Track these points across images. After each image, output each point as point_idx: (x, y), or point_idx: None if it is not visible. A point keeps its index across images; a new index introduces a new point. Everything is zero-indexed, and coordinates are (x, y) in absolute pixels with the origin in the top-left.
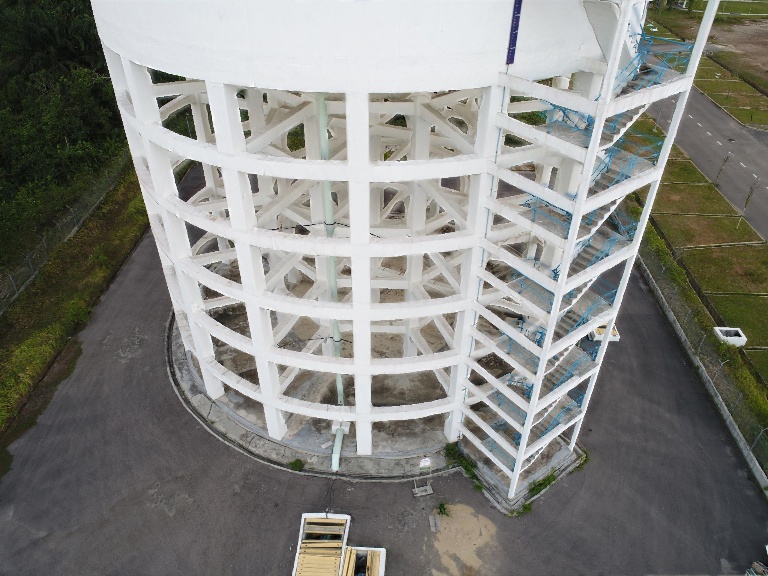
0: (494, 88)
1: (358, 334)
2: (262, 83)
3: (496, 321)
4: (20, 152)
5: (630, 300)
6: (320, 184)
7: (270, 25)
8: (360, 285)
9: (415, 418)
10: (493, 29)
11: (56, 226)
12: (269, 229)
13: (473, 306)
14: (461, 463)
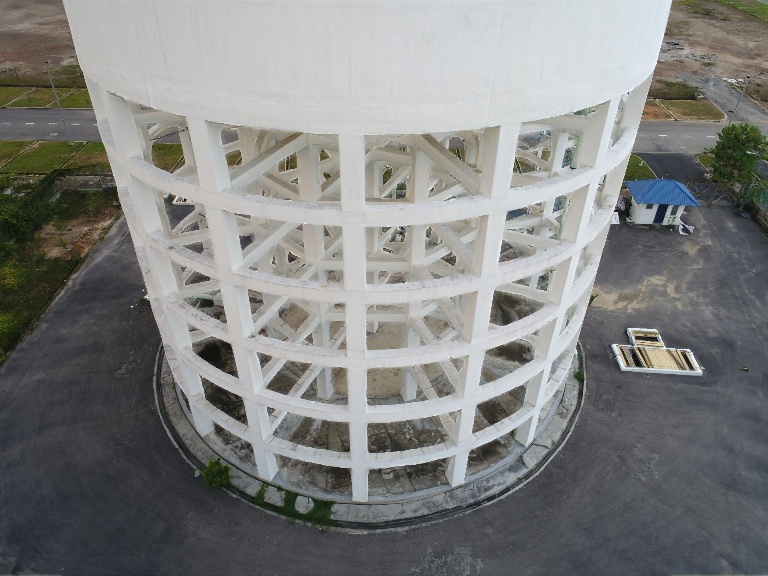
0: None
1: None
2: None
3: None
4: None
5: None
6: None
7: None
8: None
9: None
10: None
11: None
12: None
13: None
14: None
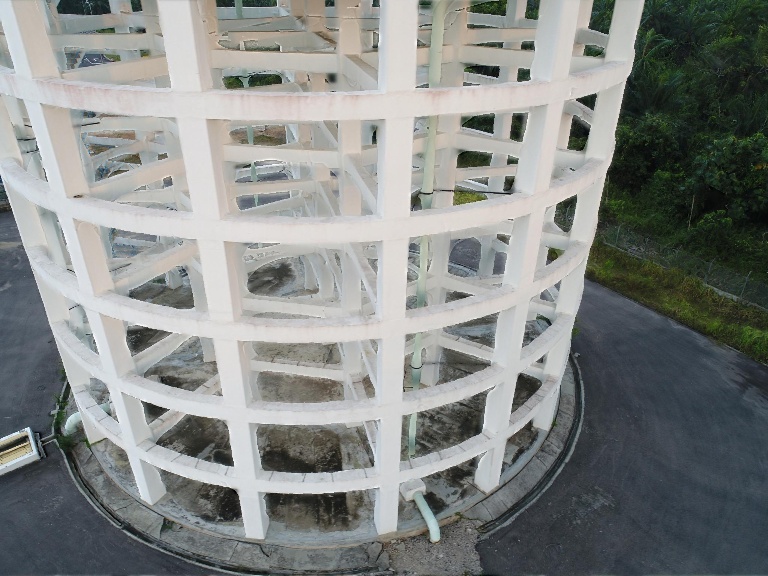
0: None
1: None
2: None
3: None
4: None
5: None
6: None
7: None
8: None
9: None
10: None
11: (707, 262)
12: None
13: None
14: None
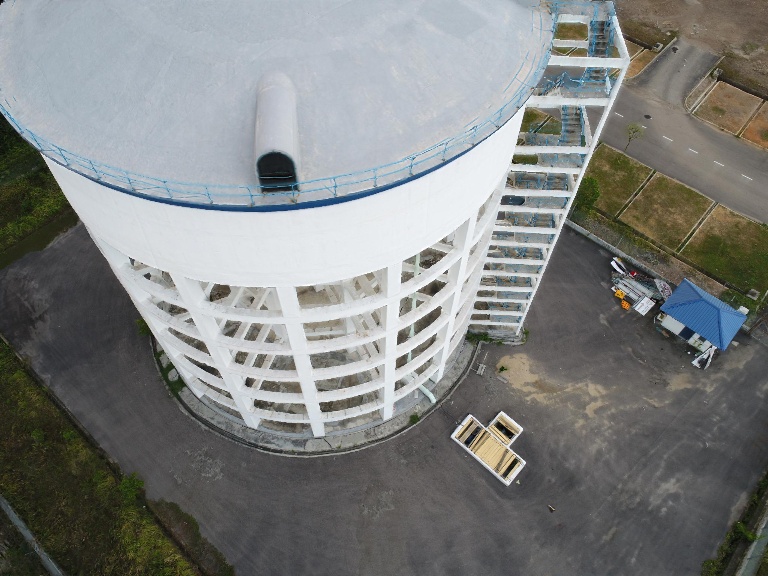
0: None
1: (450, 325)
2: (429, 245)
3: (507, 261)
4: None
5: None
6: None
7: None
8: None
9: None
10: None
11: None
12: (399, 313)
13: (487, 261)
14: (481, 339)
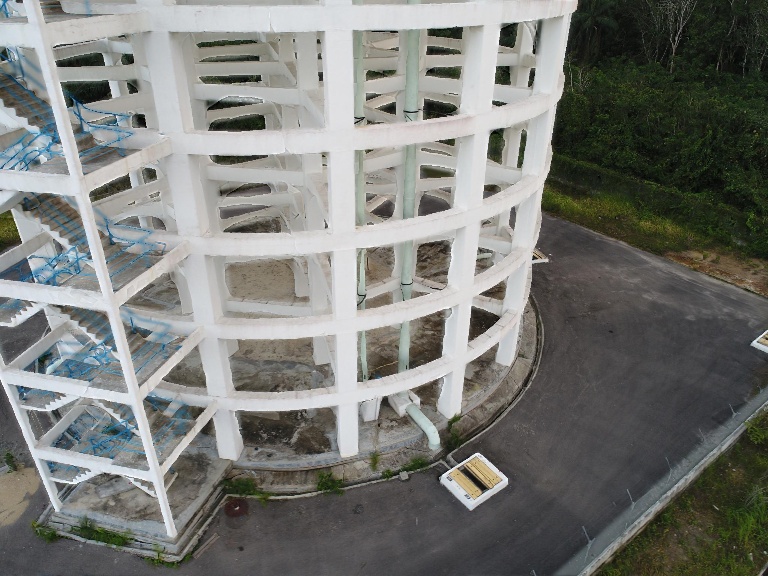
0: None
1: None
2: None
3: None
4: None
5: (593, 489)
6: (138, 83)
7: None
8: None
9: None
10: None
11: None
12: None
13: None
14: None
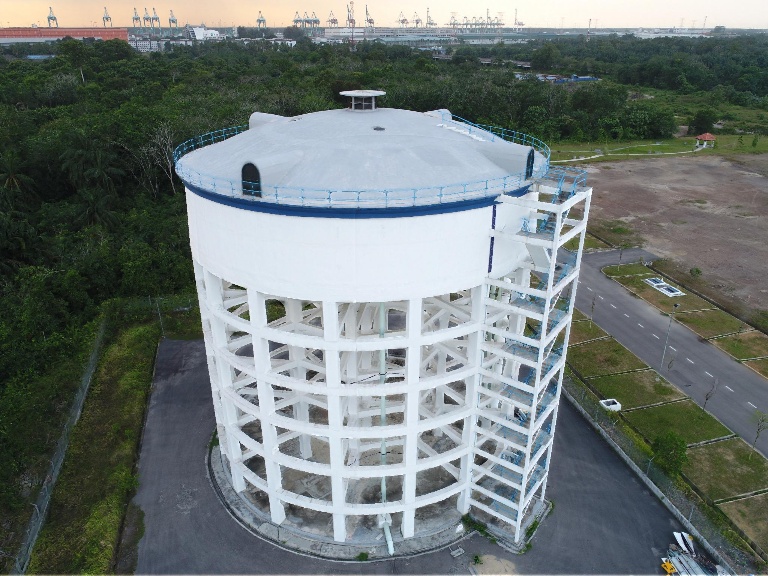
0: (483, 285)
1: (409, 444)
2: (361, 300)
3: (494, 418)
4: (0, 351)
5: None
6: None
7: (369, 270)
8: (412, 410)
9: (443, 499)
10: (482, 258)
11: (70, 412)
12: None
13: (476, 412)
14: (476, 527)
